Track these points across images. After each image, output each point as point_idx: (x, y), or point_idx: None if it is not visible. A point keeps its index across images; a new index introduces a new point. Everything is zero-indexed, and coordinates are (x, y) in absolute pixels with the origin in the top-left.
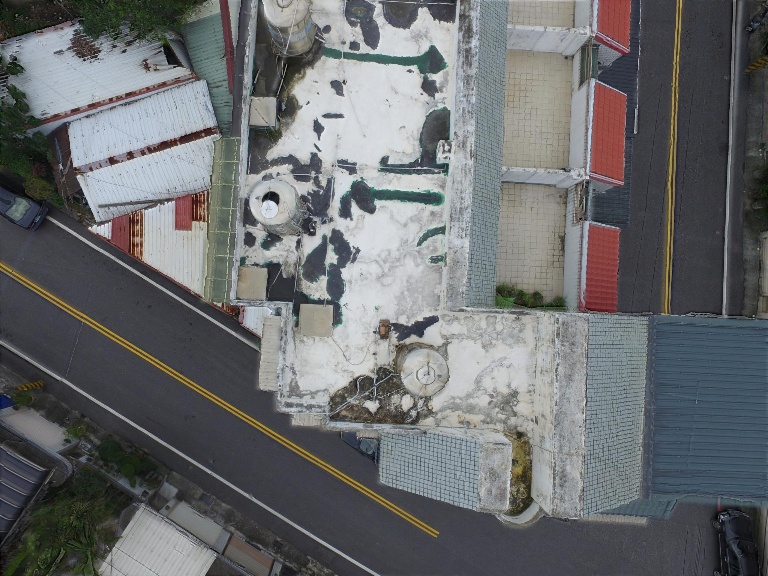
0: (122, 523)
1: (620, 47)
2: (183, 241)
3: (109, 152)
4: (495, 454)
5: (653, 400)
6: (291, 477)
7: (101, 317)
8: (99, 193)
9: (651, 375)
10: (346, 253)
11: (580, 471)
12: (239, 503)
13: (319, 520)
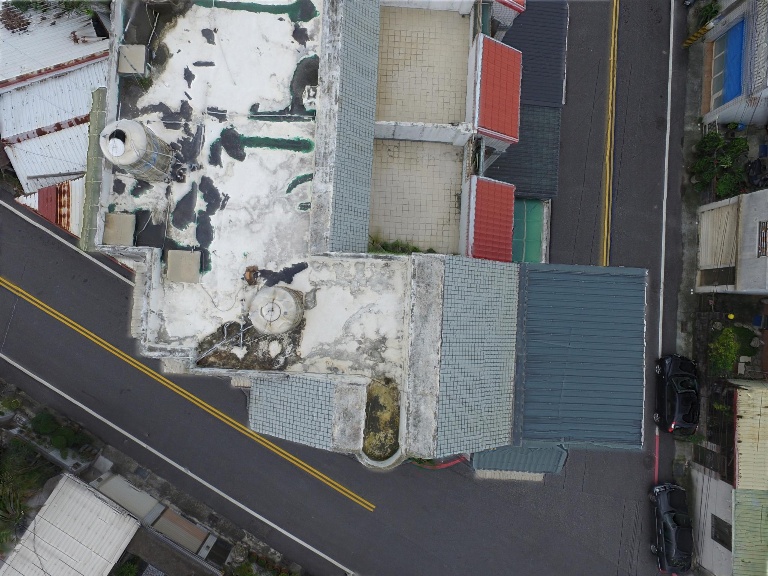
0: (46, 492)
1: (514, 4)
2: None
3: (37, 123)
4: (349, 394)
5: (525, 347)
6: (226, 451)
7: (37, 291)
8: (27, 164)
9: (523, 322)
10: (215, 200)
11: (434, 411)
12: (174, 477)
13: (255, 494)
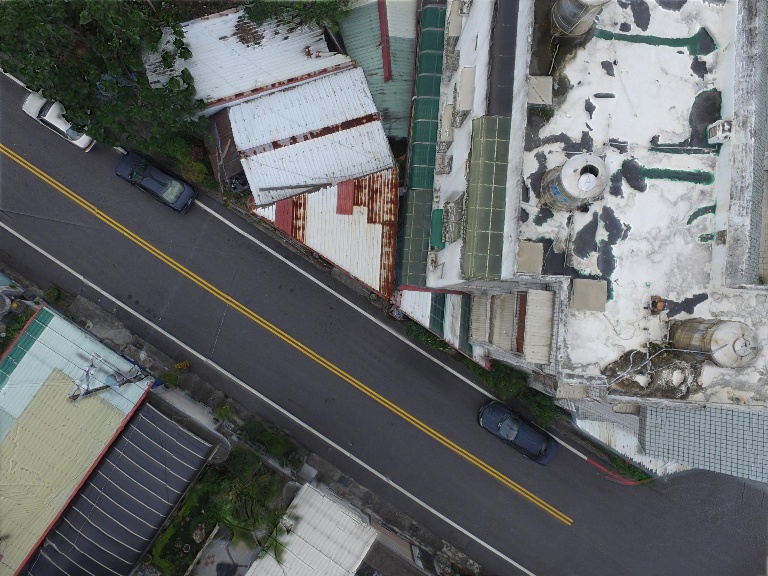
0: (286, 500)
1: None
2: (344, 225)
3: (272, 137)
4: None
5: None
6: (428, 461)
7: (245, 300)
8: (261, 177)
9: None
10: (617, 230)
11: None
12: (376, 486)
13: (455, 505)
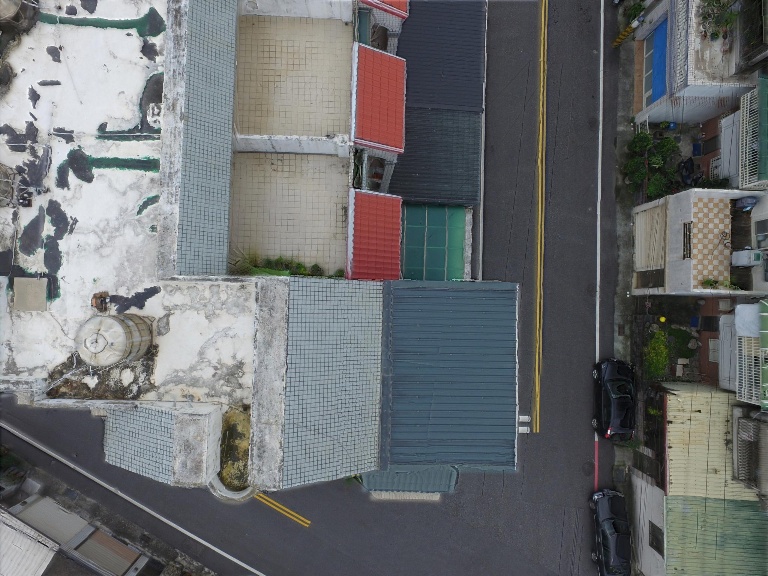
0: None
1: (396, 11)
2: None
3: None
4: (190, 425)
5: (391, 368)
6: None
7: None
8: None
9: (389, 342)
10: (63, 224)
11: (279, 440)
12: (104, 497)
13: (187, 512)
